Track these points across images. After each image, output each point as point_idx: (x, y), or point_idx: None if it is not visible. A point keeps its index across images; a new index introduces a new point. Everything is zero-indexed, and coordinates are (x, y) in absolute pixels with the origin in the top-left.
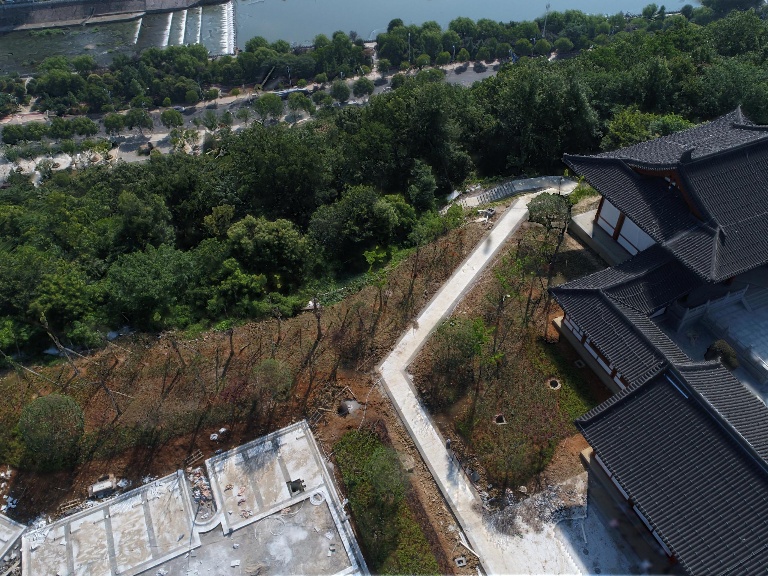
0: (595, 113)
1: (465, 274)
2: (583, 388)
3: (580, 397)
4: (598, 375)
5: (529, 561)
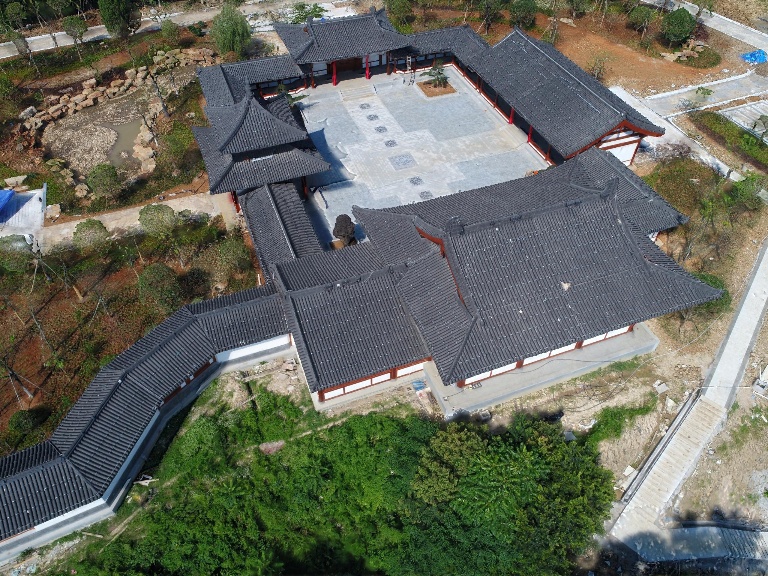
0: None
1: (762, 288)
2: None
3: None
4: None
5: (662, 136)
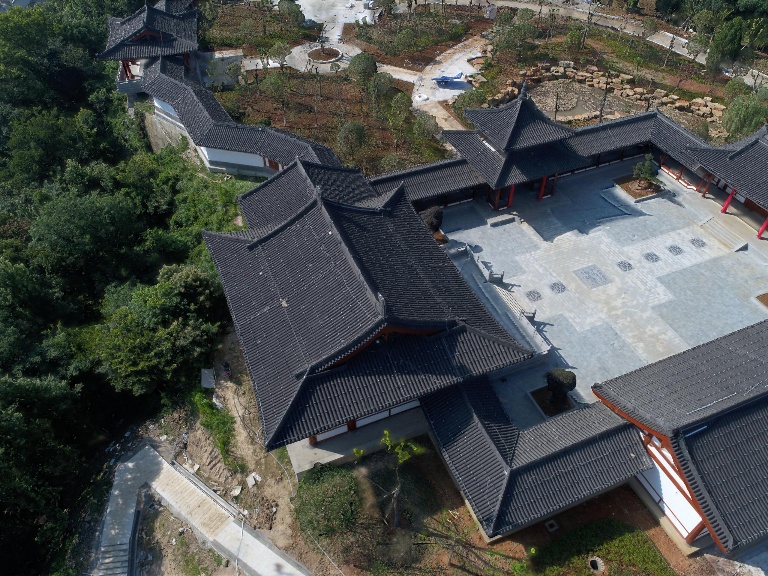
0: (52, 379)
1: None
2: (596, 531)
3: (612, 537)
4: (568, 509)
5: None
